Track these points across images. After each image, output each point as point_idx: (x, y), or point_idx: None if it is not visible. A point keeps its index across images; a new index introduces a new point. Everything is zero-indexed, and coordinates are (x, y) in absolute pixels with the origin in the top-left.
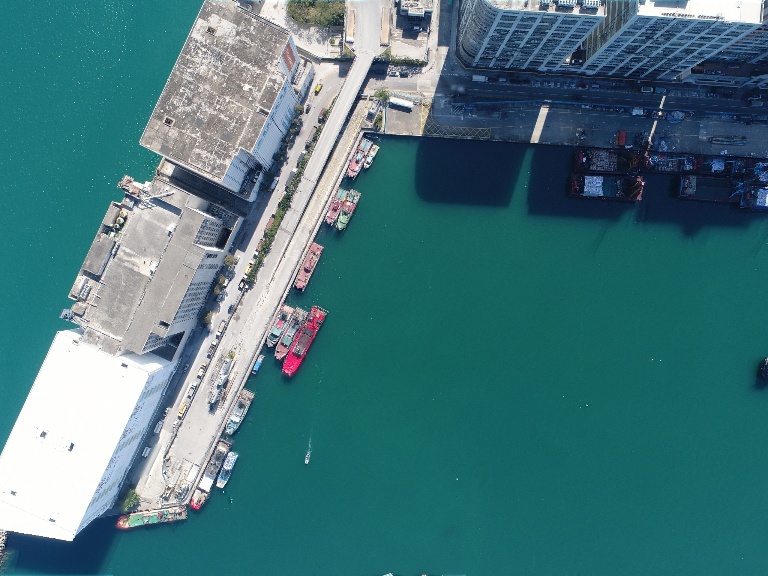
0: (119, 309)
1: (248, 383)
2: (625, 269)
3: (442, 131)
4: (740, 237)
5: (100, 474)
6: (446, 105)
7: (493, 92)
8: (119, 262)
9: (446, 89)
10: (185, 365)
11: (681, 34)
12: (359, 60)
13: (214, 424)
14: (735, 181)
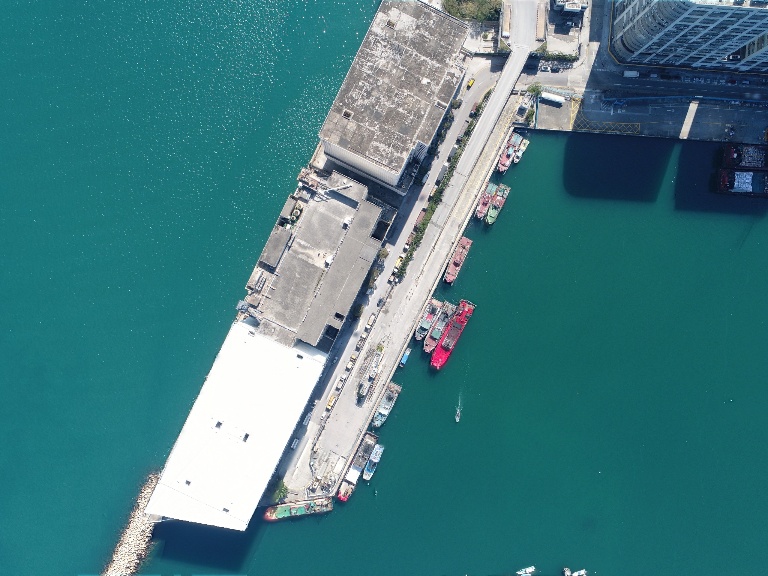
0: (293, 301)
1: (394, 376)
2: None
3: (592, 126)
4: None
5: (273, 464)
6: (596, 100)
7: (643, 88)
8: (294, 254)
9: (596, 84)
10: (334, 358)
11: None
12: (515, 55)
13: (361, 417)
14: None
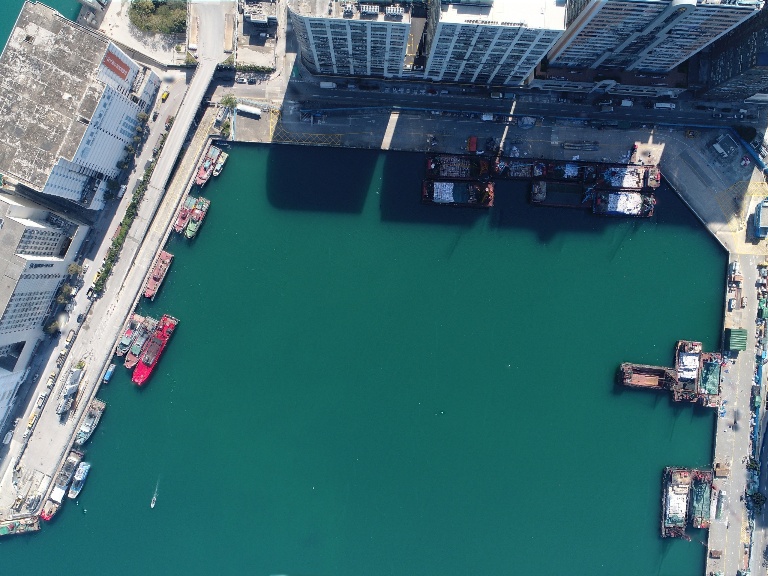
0: None
1: (100, 392)
2: (480, 275)
3: (292, 138)
4: (595, 242)
5: None
6: (295, 112)
7: (342, 98)
8: None
9: (295, 96)
10: (34, 375)
11: (495, 41)
12: (202, 67)
13: (65, 434)
14: (587, 186)
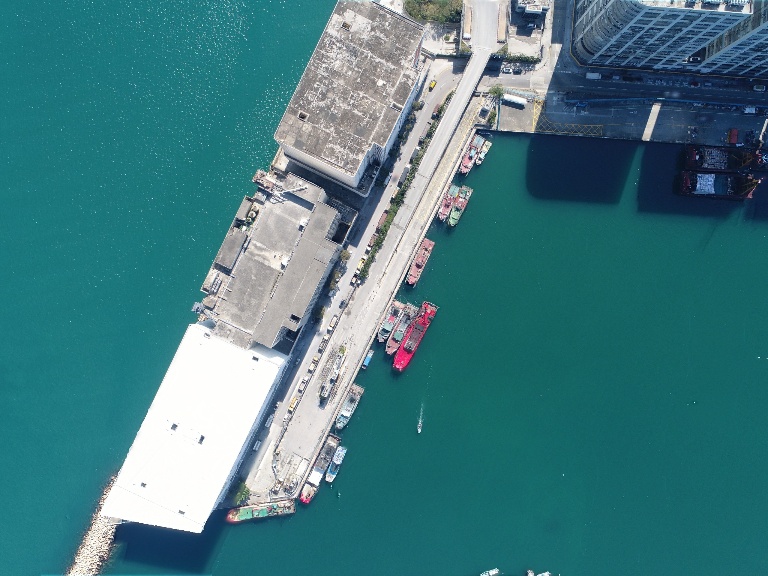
0: (249, 303)
1: (357, 378)
2: (733, 267)
3: (554, 128)
4: None
5: (229, 467)
6: (559, 102)
7: (605, 89)
8: (250, 256)
9: (559, 86)
10: (296, 359)
11: None
12: (476, 57)
13: (324, 418)
14: None
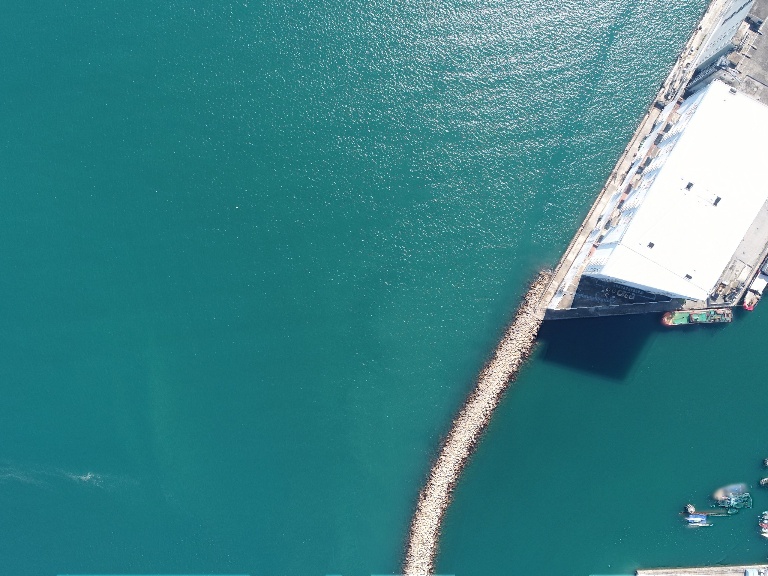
0: None
1: None
2: None
3: None
4: None
5: (743, 232)
6: None
7: None
8: None
9: None
10: None
11: None
12: None
13: None
14: None
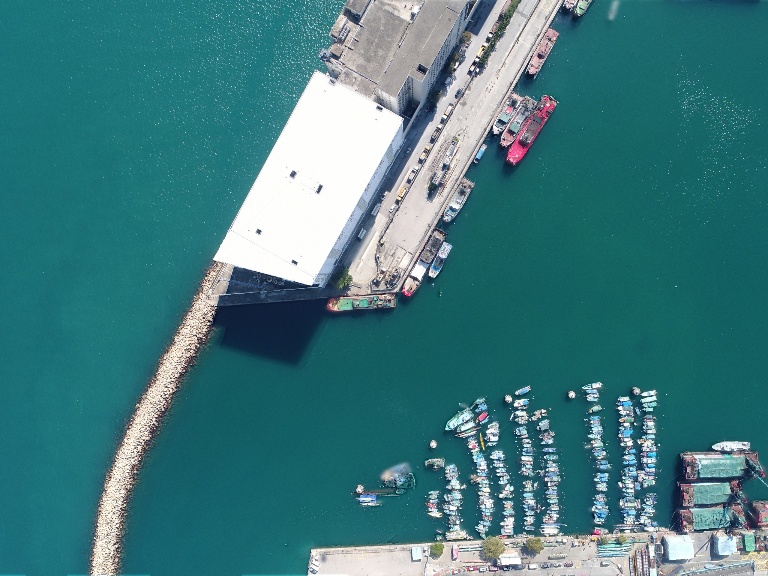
0: (376, 53)
1: (467, 173)
2: None
3: None
4: None
5: (345, 219)
6: None
7: None
8: (380, 5)
9: None
10: (407, 148)
11: None
12: None
13: (431, 212)
14: None
